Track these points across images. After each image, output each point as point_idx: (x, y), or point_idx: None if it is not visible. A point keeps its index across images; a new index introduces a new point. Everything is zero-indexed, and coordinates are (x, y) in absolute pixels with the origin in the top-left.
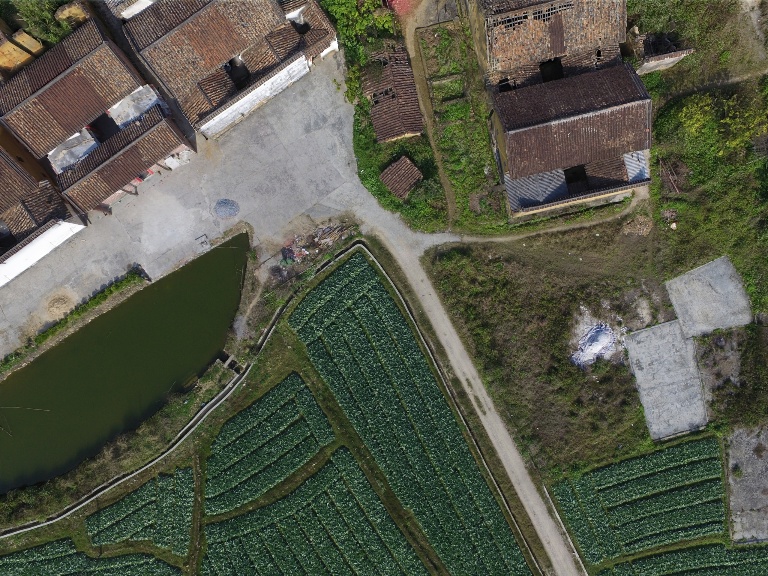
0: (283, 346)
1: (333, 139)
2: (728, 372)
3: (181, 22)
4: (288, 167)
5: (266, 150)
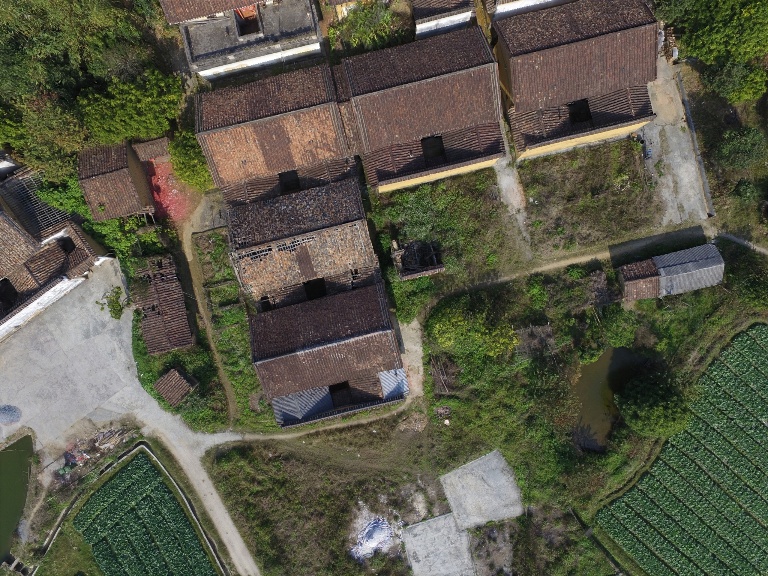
0: (69, 547)
1: (112, 344)
2: (501, 563)
3: None
4: (69, 372)
5: (46, 356)
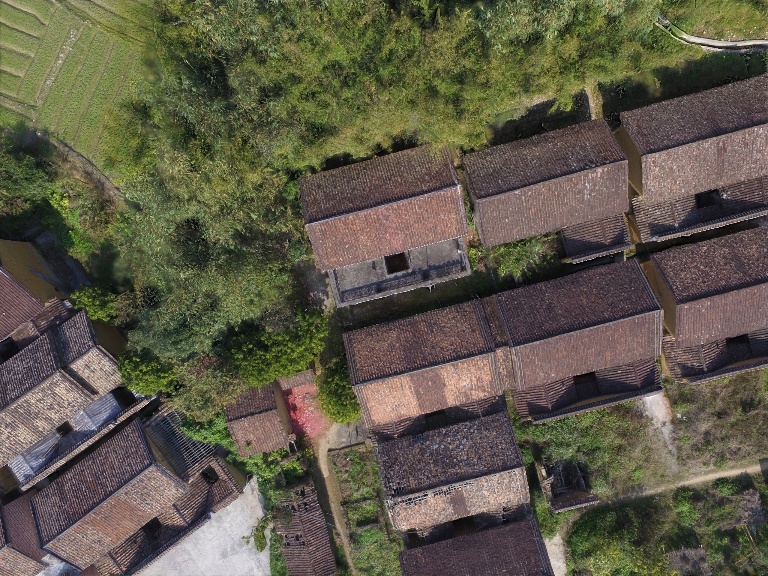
0: None
1: (250, 563)
2: None
3: (83, 516)
4: None
5: (184, 575)
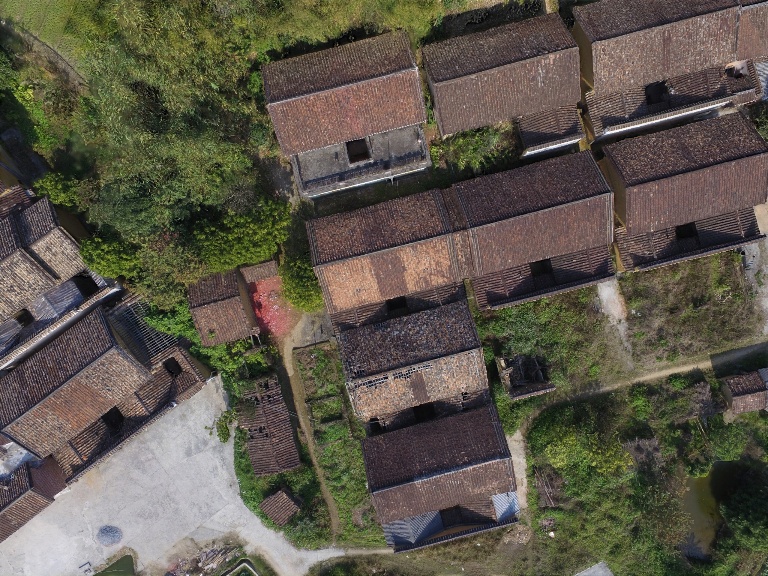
0: None
1: (214, 462)
2: None
3: (42, 398)
4: (170, 491)
5: (147, 475)
